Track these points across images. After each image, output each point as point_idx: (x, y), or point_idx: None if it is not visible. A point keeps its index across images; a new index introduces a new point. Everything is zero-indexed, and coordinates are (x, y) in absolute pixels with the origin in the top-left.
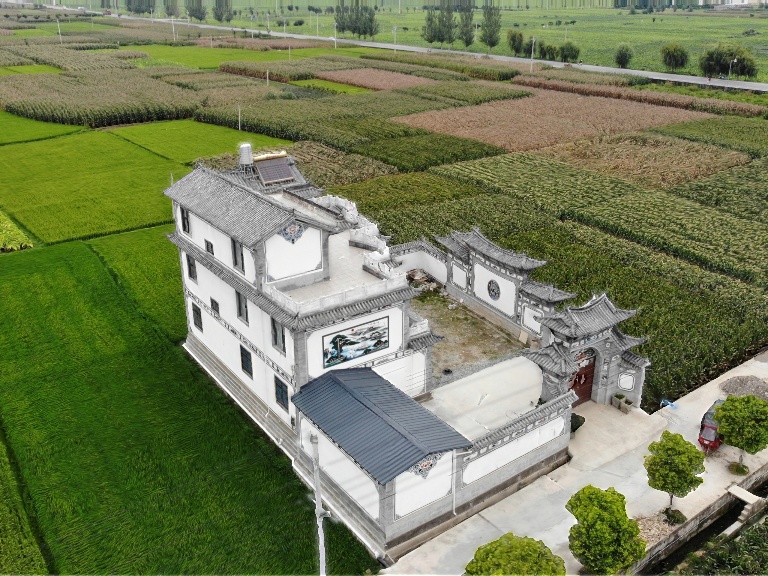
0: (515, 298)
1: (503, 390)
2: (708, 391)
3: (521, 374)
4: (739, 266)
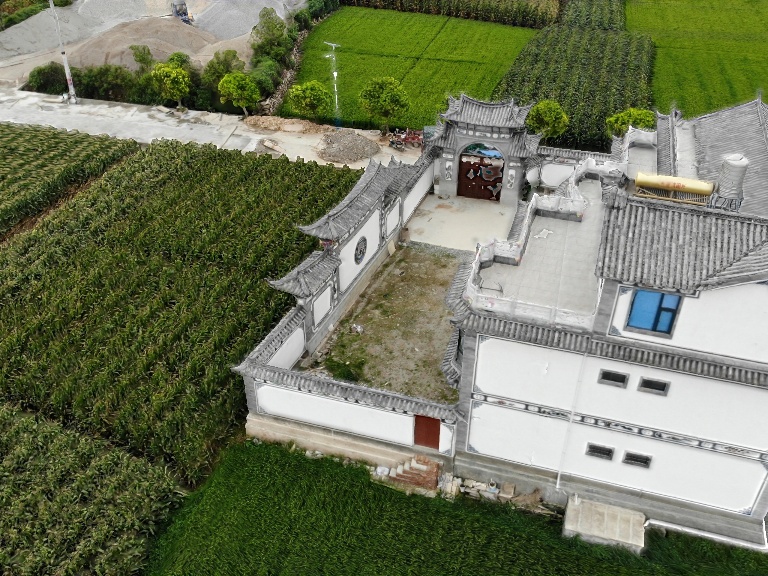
0: None
1: (501, 231)
2: (364, 166)
3: (461, 232)
4: (48, 177)
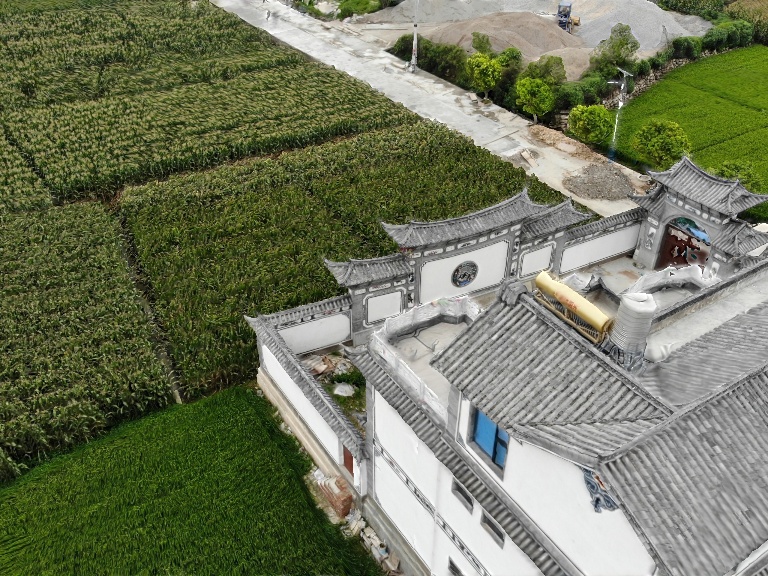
0: (508, 257)
1: None
2: (597, 206)
3: None
4: (325, 123)
